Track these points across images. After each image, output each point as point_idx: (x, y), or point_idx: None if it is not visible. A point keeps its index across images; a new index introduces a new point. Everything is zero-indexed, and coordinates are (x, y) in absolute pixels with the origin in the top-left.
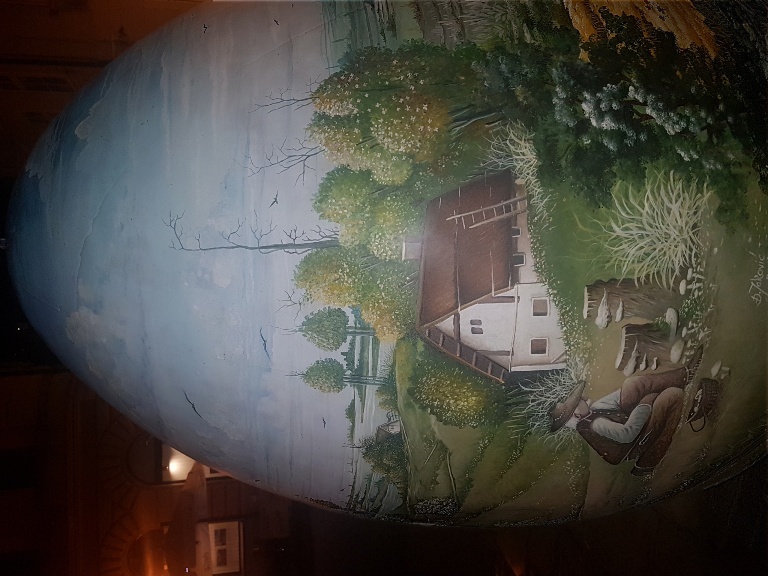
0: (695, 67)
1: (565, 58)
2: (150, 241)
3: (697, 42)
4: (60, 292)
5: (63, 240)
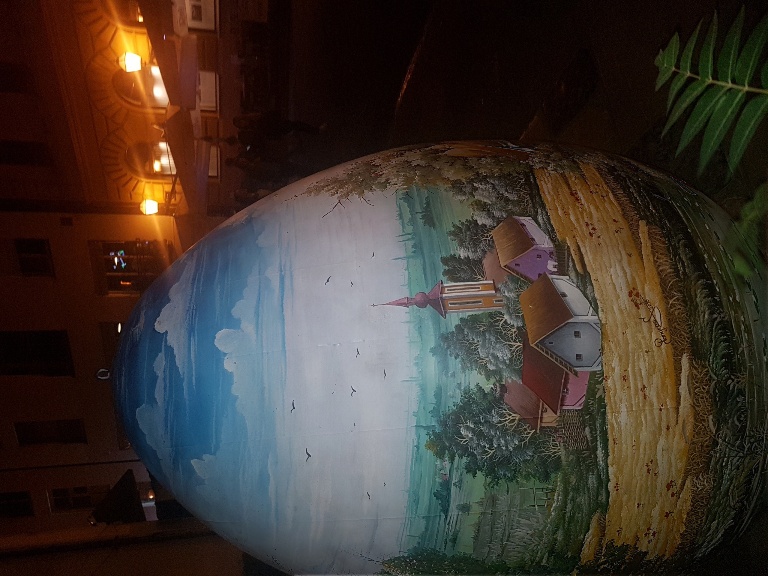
0: (646, 569)
1: (561, 574)
2: (257, 552)
3: (661, 553)
4: (182, 504)
5: (187, 504)
